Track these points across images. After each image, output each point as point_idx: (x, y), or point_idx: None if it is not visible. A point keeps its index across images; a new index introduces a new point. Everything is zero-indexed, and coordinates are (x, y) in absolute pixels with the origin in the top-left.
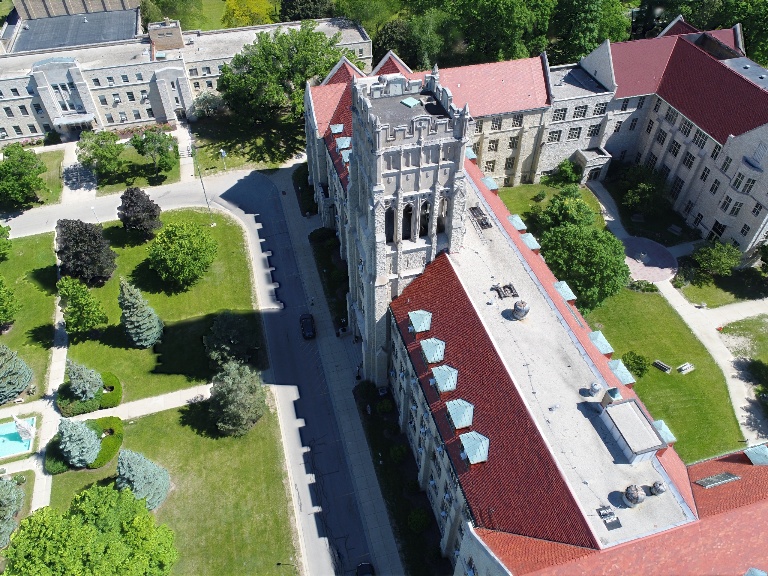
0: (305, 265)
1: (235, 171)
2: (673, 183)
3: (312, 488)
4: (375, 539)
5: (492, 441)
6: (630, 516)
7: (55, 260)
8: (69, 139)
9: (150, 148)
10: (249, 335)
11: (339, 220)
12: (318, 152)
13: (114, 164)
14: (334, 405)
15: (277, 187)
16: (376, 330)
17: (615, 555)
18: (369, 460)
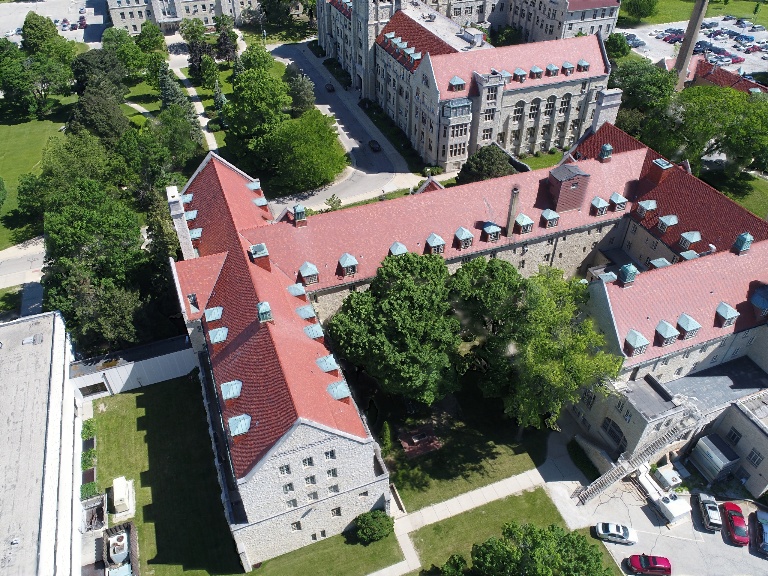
0: (323, 72)
1: (272, 45)
2: (525, 34)
3: (343, 128)
4: (376, 137)
5: (422, 52)
6: (472, 49)
7: (178, 78)
8: (165, 34)
9: (225, 24)
10: (303, 76)
11: (342, 42)
12: (327, 12)
13: (202, 37)
14: (349, 108)
15: (299, 49)
16: (369, 57)
17: (465, 54)
18: (369, 120)
